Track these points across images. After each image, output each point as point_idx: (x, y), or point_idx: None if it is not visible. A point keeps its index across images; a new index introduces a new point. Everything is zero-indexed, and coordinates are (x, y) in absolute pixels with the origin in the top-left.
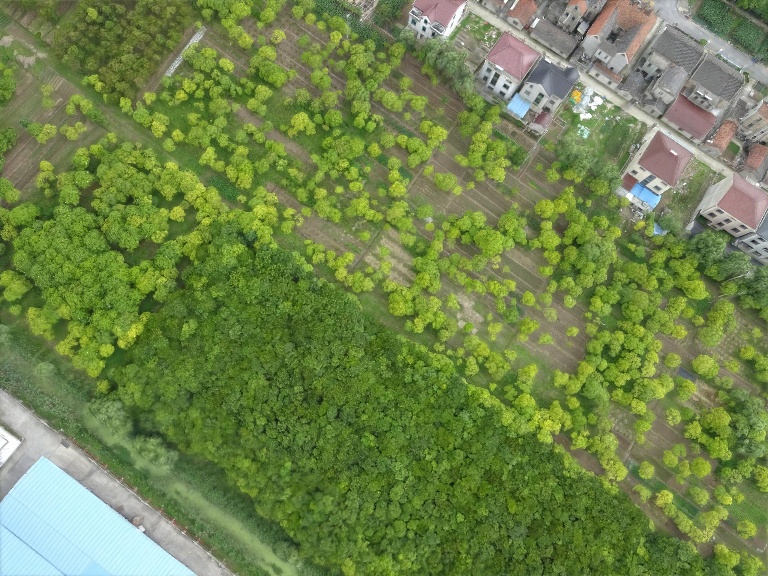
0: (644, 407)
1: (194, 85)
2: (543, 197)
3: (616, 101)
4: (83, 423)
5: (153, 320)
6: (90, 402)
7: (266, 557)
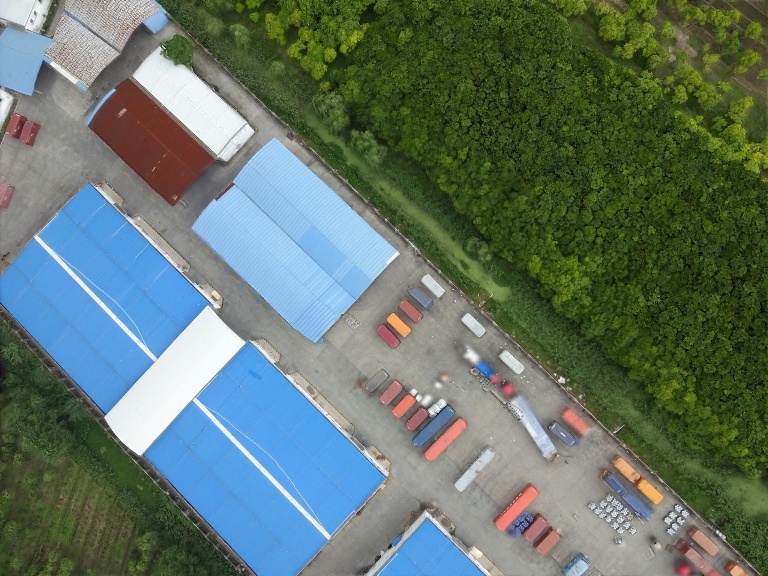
0: None
1: None
2: None
3: None
4: (305, 121)
5: (373, 28)
6: (315, 96)
7: (456, 253)
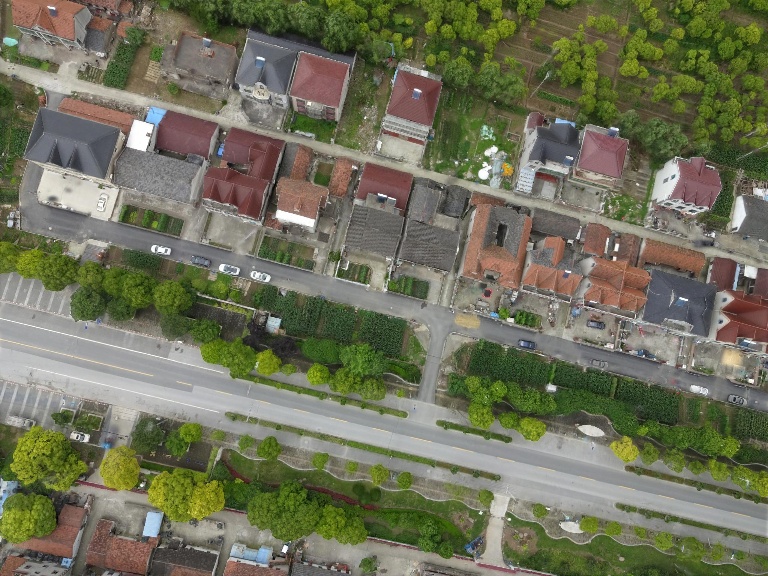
0: None
1: None
2: (503, 55)
3: (463, 184)
4: None
5: None
6: None
7: None
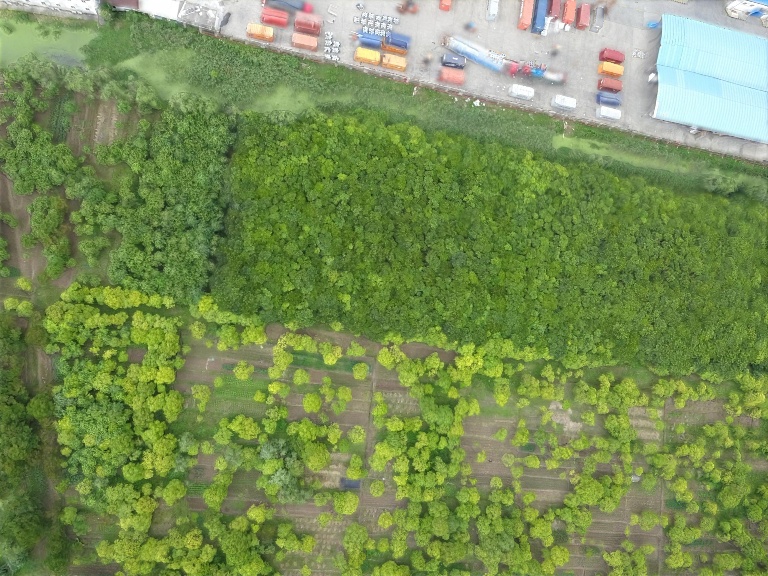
0: (391, 427)
1: None
2: (555, 568)
3: None
4: (765, 181)
5: None
6: None
7: (607, 152)
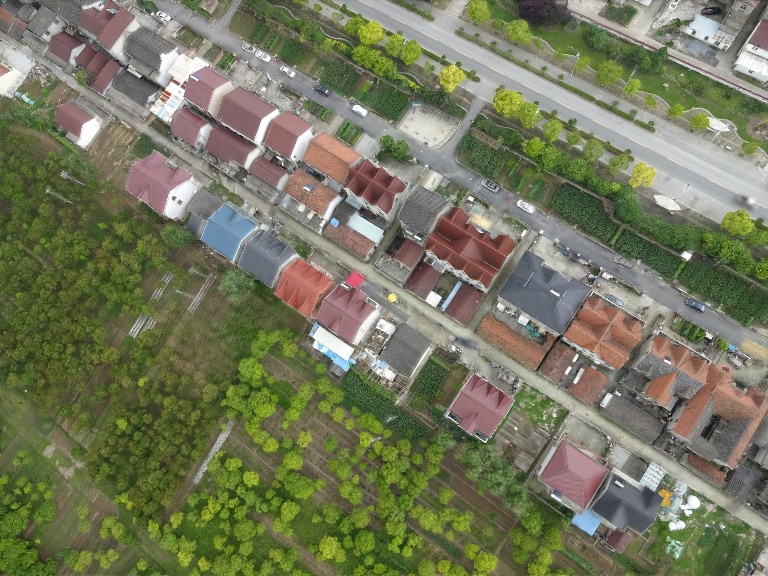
0: None
1: (219, 506)
2: None
3: (719, 500)
4: None
5: None
6: None
7: None
